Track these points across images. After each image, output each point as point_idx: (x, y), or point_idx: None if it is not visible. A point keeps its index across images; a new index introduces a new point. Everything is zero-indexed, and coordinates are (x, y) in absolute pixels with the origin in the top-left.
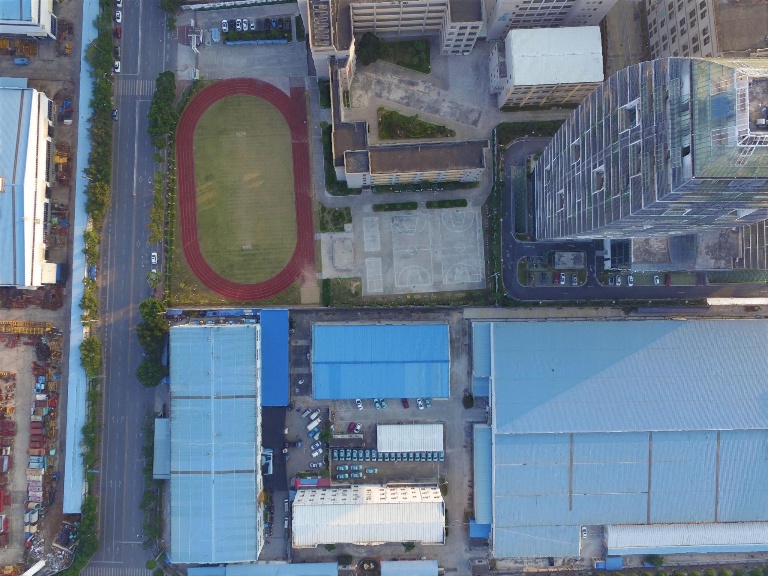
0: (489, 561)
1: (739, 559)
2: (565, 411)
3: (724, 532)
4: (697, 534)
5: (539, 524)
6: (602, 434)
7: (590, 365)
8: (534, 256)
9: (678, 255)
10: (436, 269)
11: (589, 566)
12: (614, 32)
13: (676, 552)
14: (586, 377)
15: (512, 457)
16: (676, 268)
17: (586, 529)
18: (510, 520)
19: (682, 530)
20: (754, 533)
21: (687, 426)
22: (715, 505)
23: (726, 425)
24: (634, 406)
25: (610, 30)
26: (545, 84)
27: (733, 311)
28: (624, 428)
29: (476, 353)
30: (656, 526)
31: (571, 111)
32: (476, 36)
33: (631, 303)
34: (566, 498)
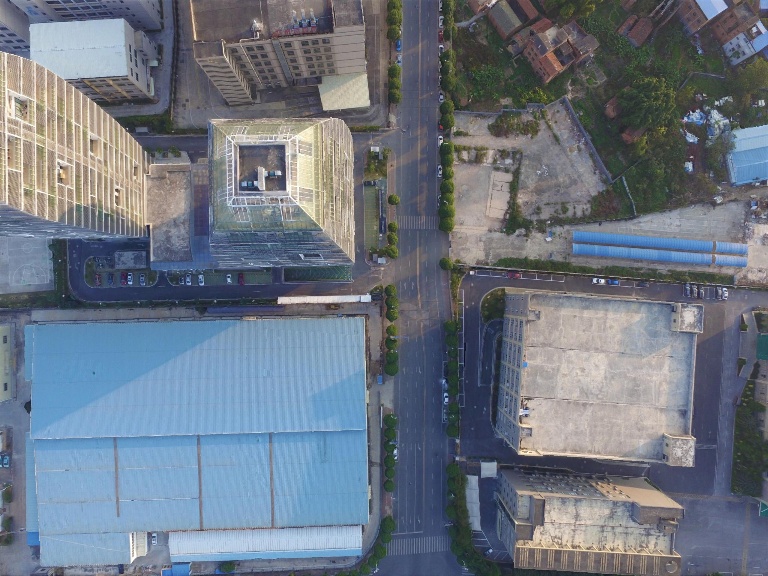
0: (55, 569)
1: (318, 565)
2: (104, 415)
3: (290, 537)
4: (262, 540)
5: (86, 531)
6: (147, 438)
7: (134, 367)
8: (101, 256)
9: (199, 253)
10: (2, 271)
11: (159, 574)
12: (188, 25)
13: (243, 558)
14: (128, 380)
15: (54, 463)
16: (198, 267)
17: (156, 536)
18: (55, 528)
19: (246, 536)
20: (322, 538)
21: (232, 429)
22: (271, 510)
23: (273, 428)
24: (177, 409)
25: (184, 23)
26: (66, 79)
27: (314, 310)
28: (165, 432)
29: (26, 356)
30: (220, 532)
31: (144, 107)
32: (12, 31)
33: (200, 303)
34: (113, 504)
